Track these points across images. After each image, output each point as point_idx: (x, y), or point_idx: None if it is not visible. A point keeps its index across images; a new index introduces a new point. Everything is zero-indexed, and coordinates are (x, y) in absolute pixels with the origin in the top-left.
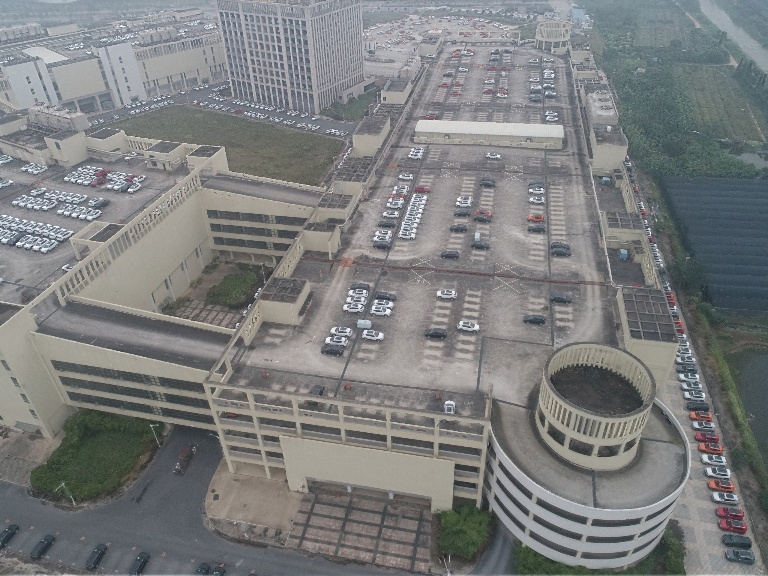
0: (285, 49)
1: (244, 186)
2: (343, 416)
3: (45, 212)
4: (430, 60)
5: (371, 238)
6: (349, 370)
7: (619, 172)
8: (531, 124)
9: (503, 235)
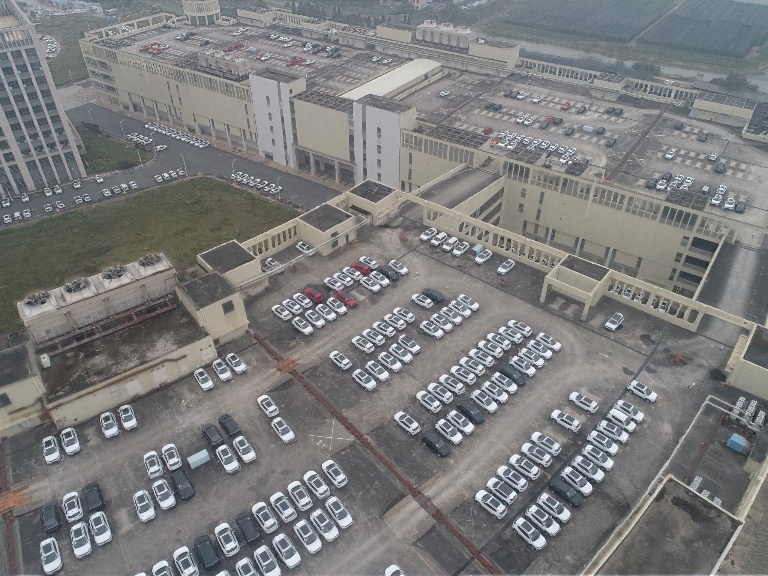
0: None
1: (432, 201)
2: None
3: (422, 353)
4: None
5: (564, 167)
6: (761, 207)
7: (521, 66)
8: None
9: (584, 122)
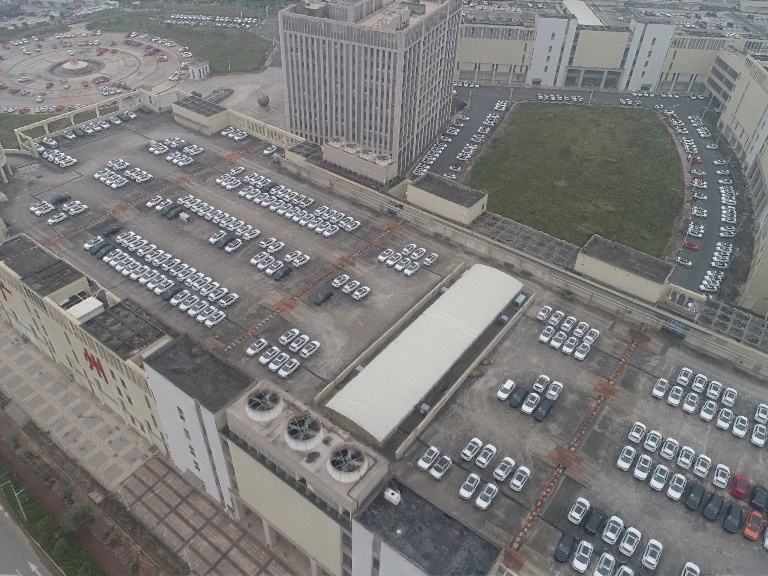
0: None
1: None
2: None
3: None
4: None
5: None
6: None
7: None
8: (569, 5)
9: None
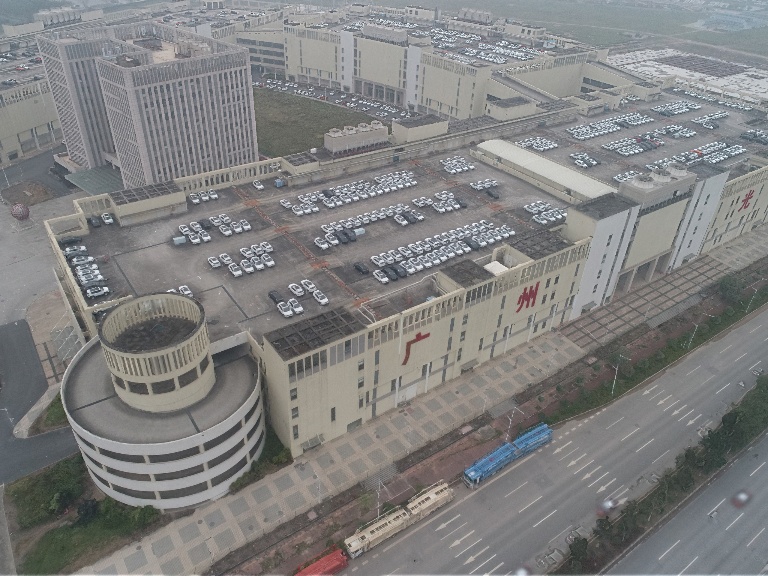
0: None
1: None
2: (269, 8)
3: None
4: (10, 99)
5: None
6: None
7: None
8: None
9: None
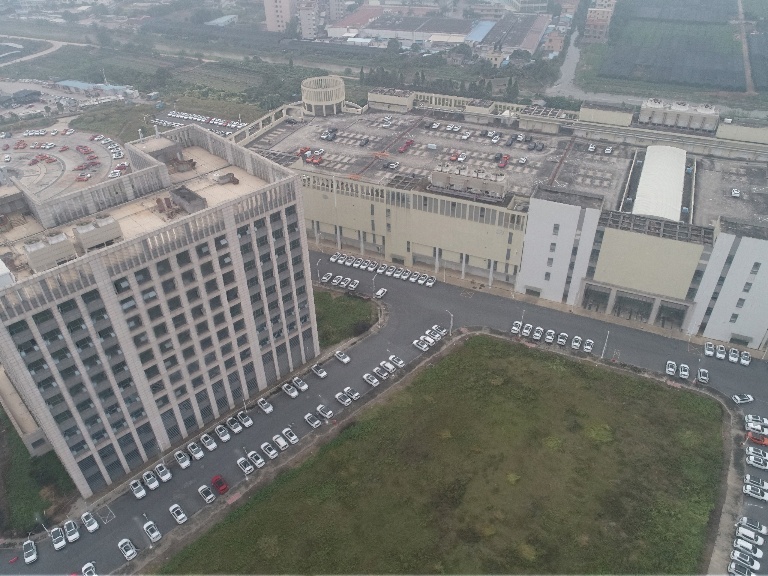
0: (246, 287)
1: None
2: None
3: None
4: None
5: None
6: None
7: None
8: (650, 157)
9: None
